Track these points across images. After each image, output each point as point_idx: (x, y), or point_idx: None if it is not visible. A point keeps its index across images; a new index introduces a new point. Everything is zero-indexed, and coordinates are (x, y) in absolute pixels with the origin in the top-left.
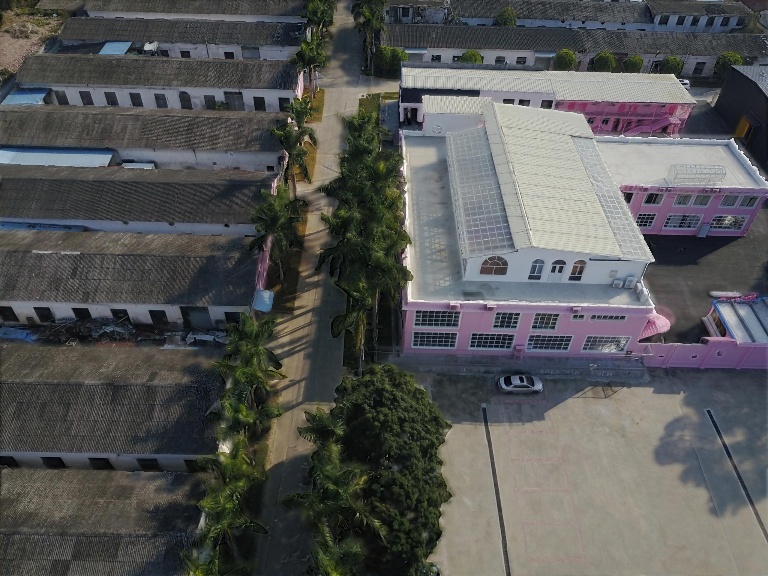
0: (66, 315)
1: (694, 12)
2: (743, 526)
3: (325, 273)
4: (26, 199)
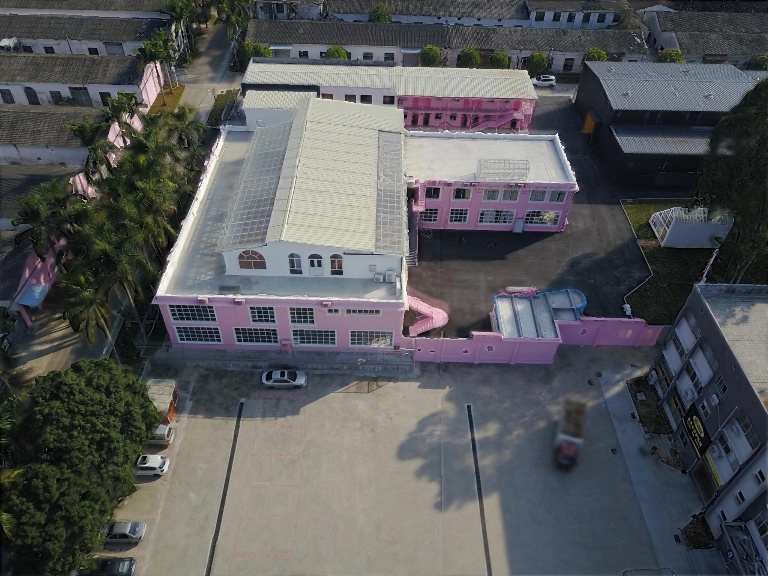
0: None
1: (569, 8)
2: (464, 521)
3: None
4: None
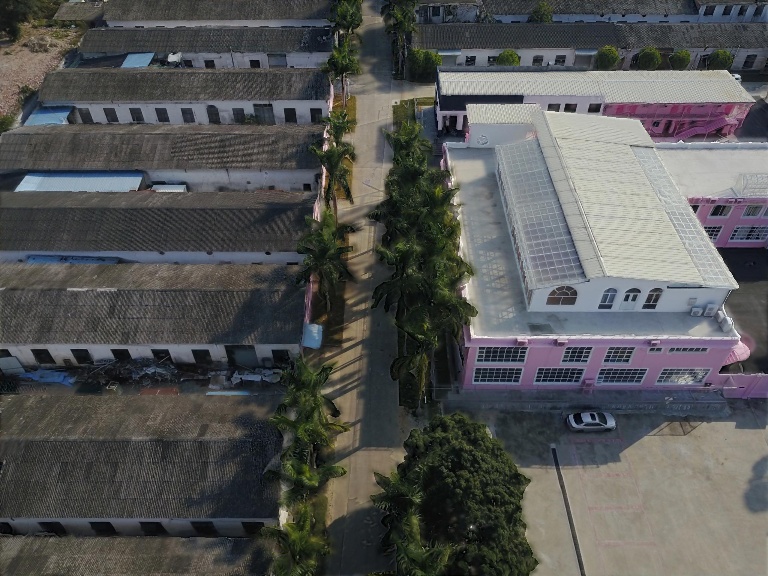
0: (105, 356)
1: (742, 1)
2: None
3: (372, 300)
4: (57, 230)
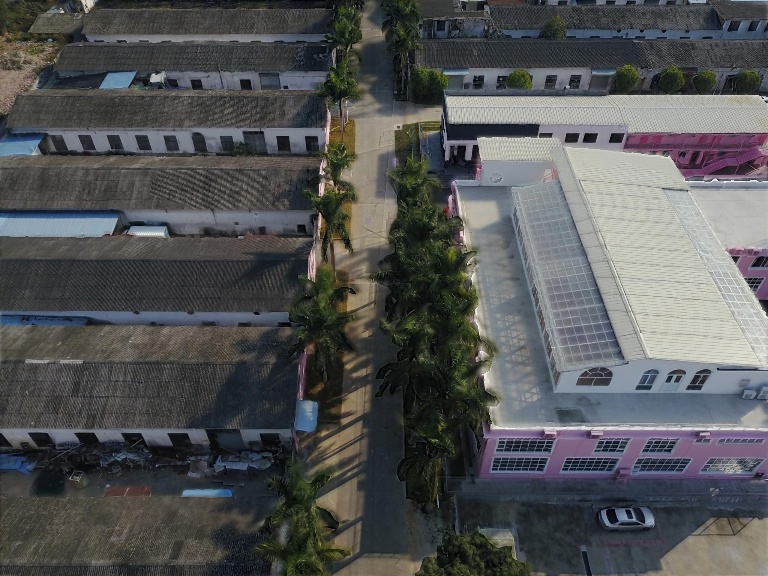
0: (68, 439)
1: None
2: None
3: (374, 365)
4: (18, 286)
